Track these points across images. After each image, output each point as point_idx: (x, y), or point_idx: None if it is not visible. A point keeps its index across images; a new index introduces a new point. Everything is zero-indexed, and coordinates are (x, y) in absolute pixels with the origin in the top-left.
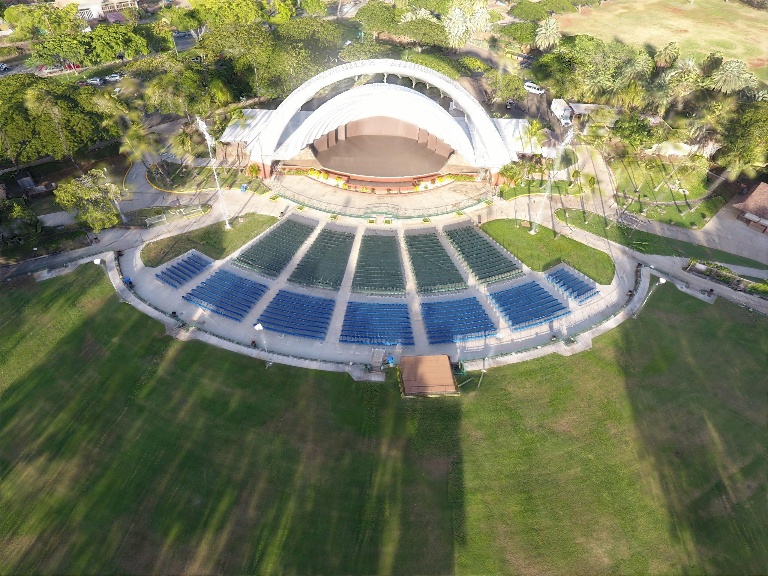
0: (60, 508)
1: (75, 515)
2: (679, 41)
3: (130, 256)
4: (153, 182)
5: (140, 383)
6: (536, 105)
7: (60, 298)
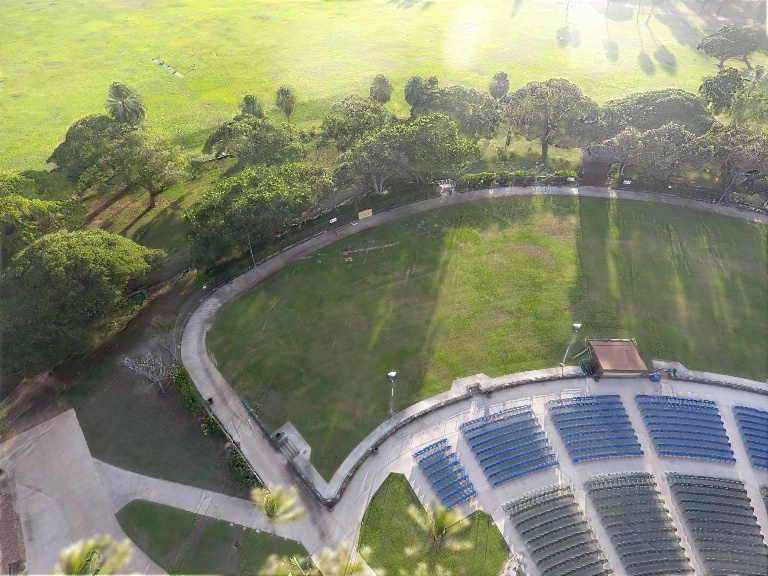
0: None
1: None
2: None
3: None
4: None
5: None
6: None
7: None
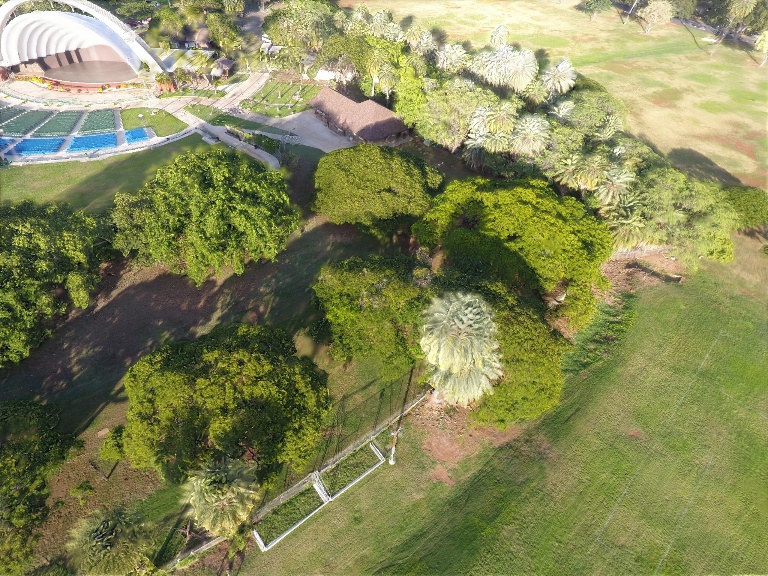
0: None
1: None
2: (441, 14)
3: None
4: None
5: None
6: None
7: None
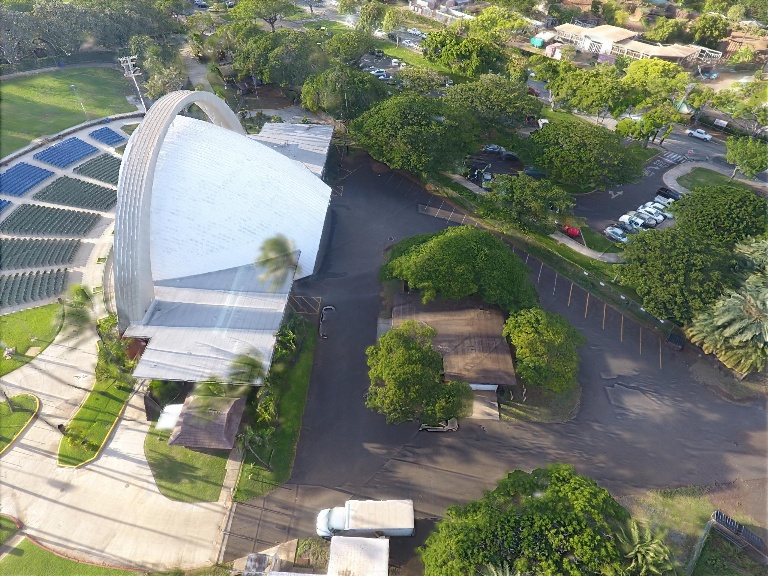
0: None
1: None
2: None
3: None
4: (245, 119)
5: (6, 131)
6: (447, 490)
7: (103, 103)
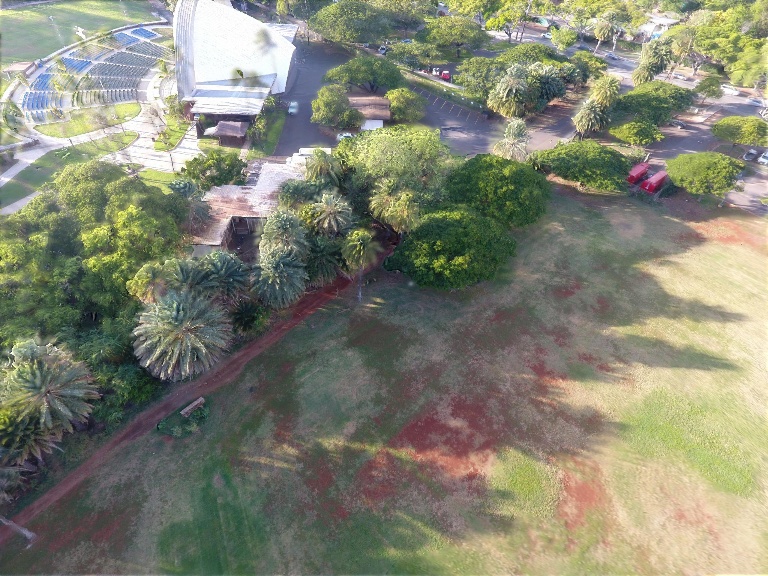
0: (29, 21)
1: None
2: None
3: (165, 26)
4: None
5: (74, 28)
6: None
7: None
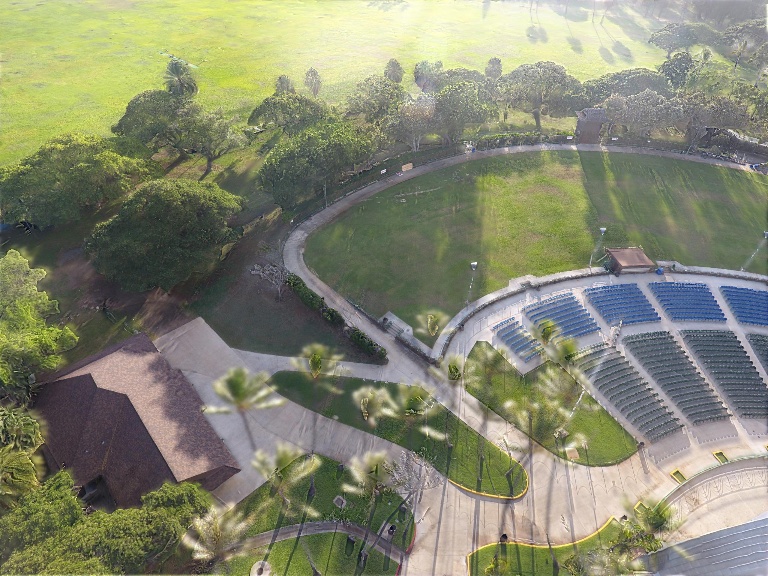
0: None
1: (762, 205)
2: None
3: None
4: None
5: None
6: None
7: None
